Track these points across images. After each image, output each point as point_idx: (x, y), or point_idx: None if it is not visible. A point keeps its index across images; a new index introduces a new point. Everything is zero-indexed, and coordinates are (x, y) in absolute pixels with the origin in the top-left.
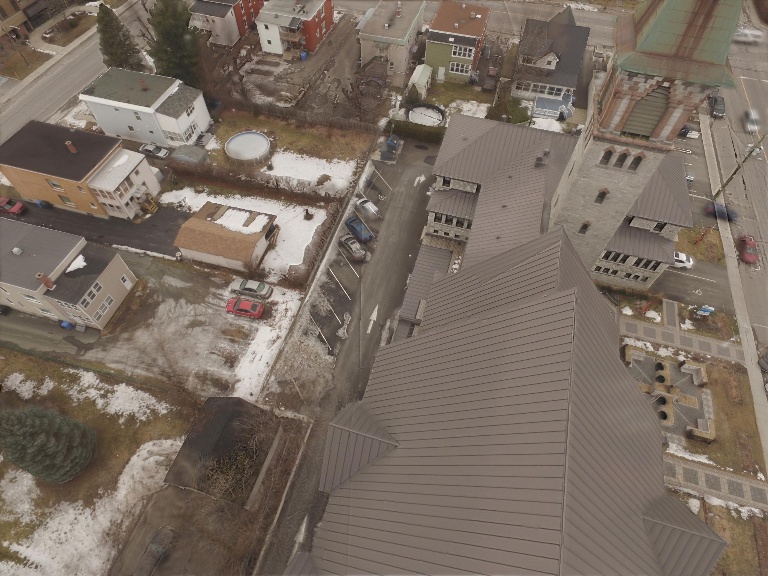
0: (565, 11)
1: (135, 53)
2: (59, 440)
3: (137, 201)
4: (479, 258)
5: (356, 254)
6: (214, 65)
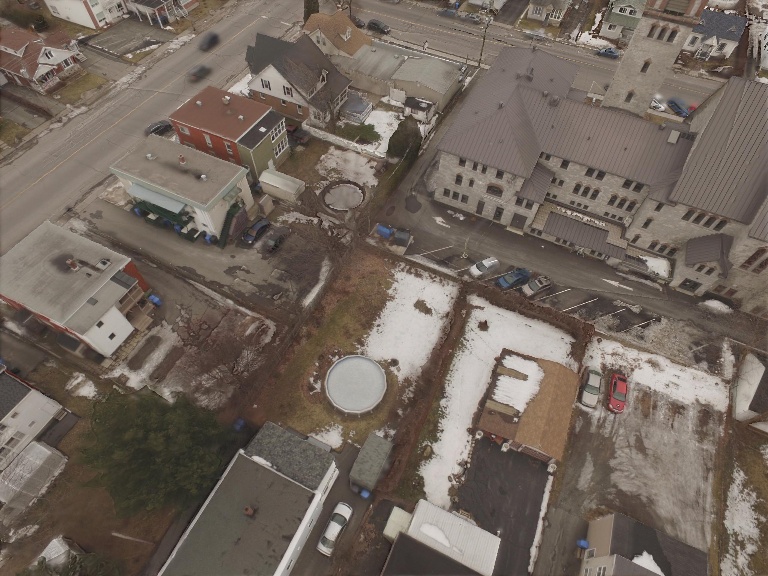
0: (262, 39)
1: (73, 568)
2: None
3: None
4: (640, 167)
5: (552, 283)
6: None
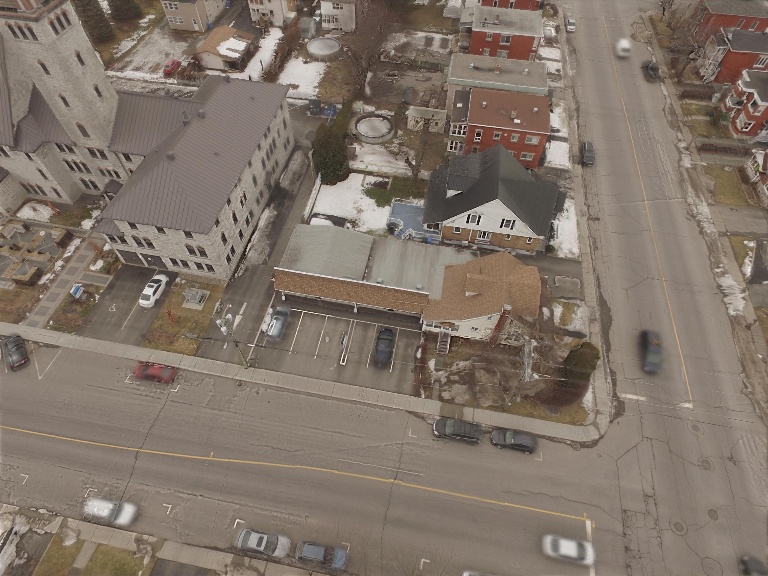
0: None
1: None
2: (85, 13)
3: (262, 15)
4: None
5: None
6: (406, 10)
